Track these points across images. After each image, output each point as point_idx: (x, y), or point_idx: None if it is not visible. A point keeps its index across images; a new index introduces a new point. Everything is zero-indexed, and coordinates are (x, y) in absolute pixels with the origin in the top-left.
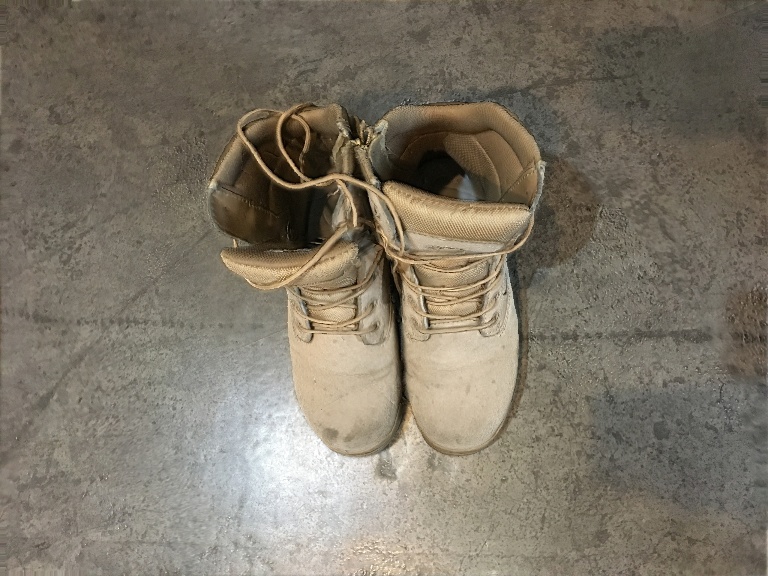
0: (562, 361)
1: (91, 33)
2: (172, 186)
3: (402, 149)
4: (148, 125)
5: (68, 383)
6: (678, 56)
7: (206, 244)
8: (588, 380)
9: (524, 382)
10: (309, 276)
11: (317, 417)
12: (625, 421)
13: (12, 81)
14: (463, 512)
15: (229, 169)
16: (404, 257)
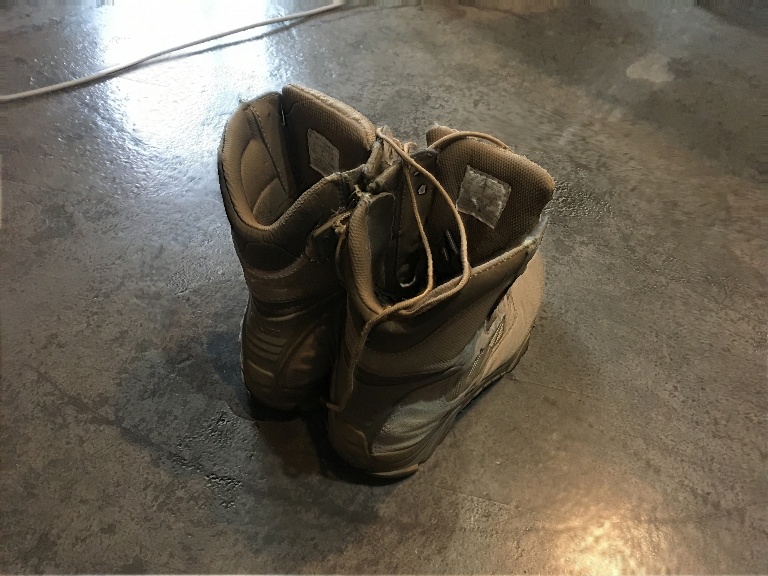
0: None
1: None
2: None
3: None
4: None
5: None
6: None
7: (568, 518)
8: None
9: None
10: None
11: None
12: None
13: None
14: None
15: None
16: None
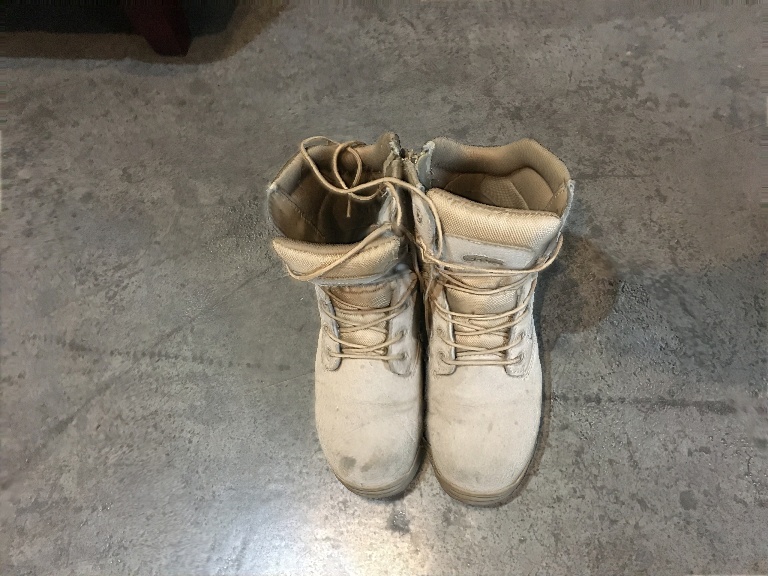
0: (585, 423)
1: (172, 114)
2: (222, 239)
3: (443, 183)
4: (209, 188)
5: (90, 410)
6: (692, 162)
7: (246, 291)
8: (611, 443)
9: (546, 441)
10: (352, 264)
11: (336, 446)
12: (650, 488)
13: (95, 146)
14: (477, 572)
15: (289, 177)
16: (441, 259)
